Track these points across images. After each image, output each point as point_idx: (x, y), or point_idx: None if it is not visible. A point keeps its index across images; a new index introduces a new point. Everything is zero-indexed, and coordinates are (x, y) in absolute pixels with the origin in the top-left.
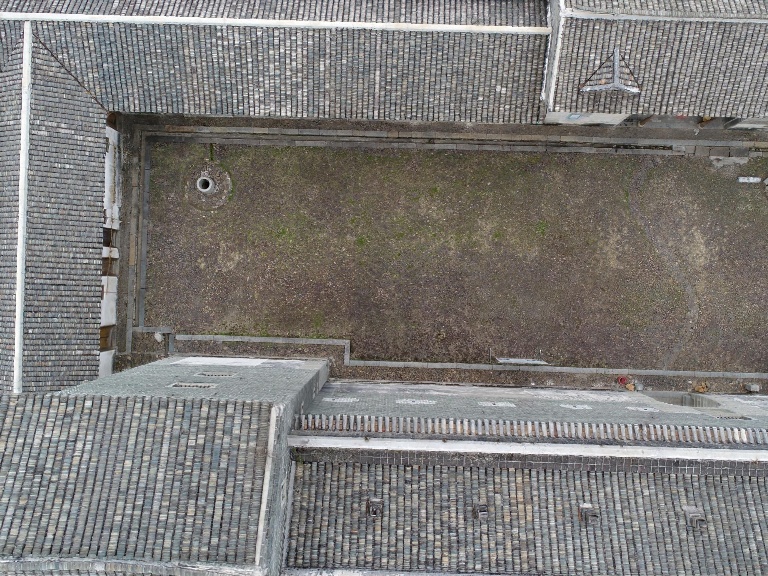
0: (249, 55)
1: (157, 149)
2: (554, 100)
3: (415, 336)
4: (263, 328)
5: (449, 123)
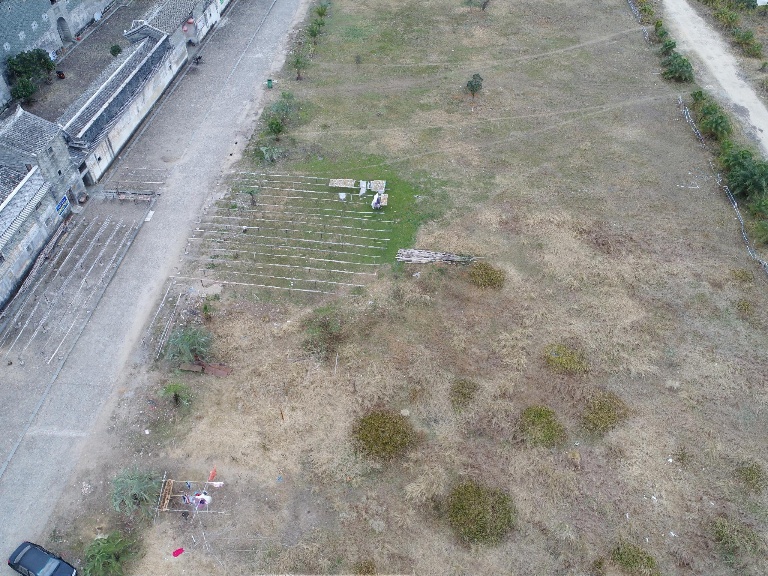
0: None
1: None
2: None
3: None
4: None
5: None
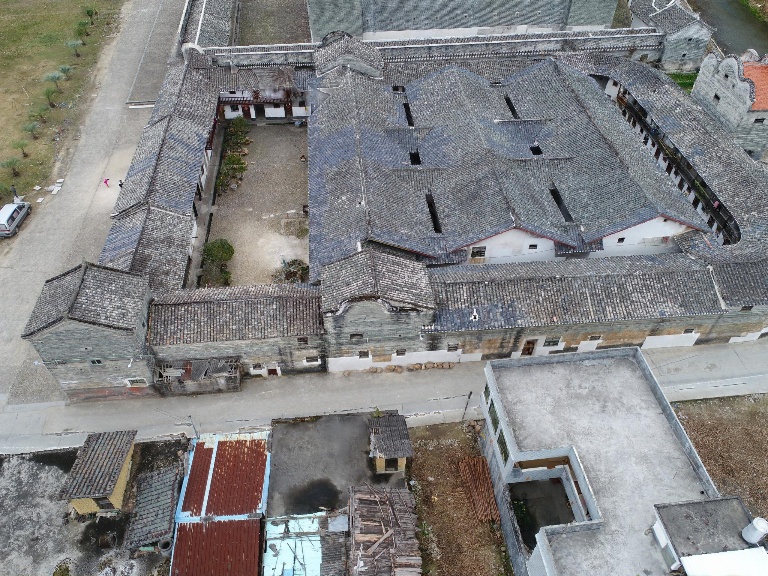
0: None
1: None
2: None
3: None
4: None
5: (230, 29)
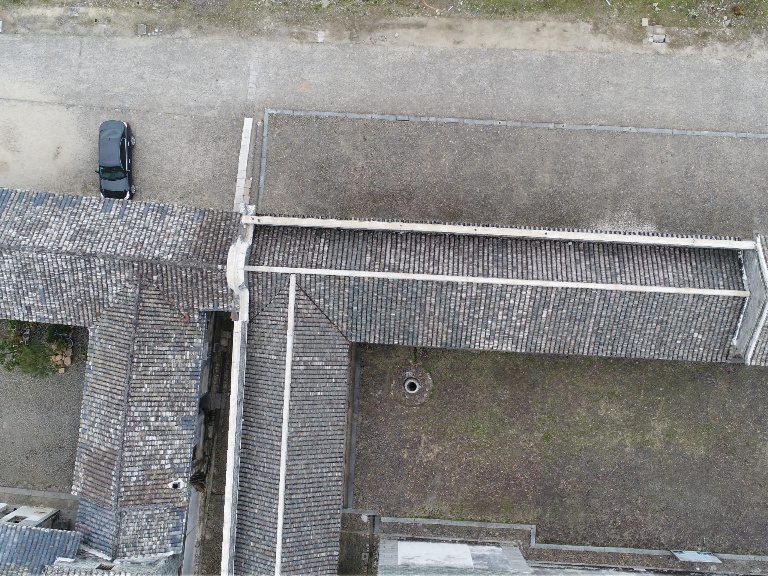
0: (483, 304)
1: (367, 351)
2: (752, 356)
3: (593, 523)
4: (458, 512)
5: None
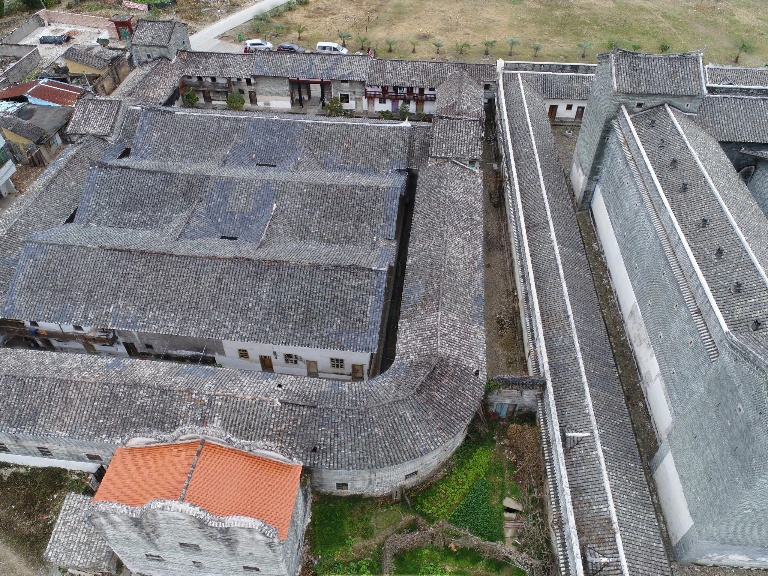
0: None
1: None
2: None
3: None
4: None
5: None
